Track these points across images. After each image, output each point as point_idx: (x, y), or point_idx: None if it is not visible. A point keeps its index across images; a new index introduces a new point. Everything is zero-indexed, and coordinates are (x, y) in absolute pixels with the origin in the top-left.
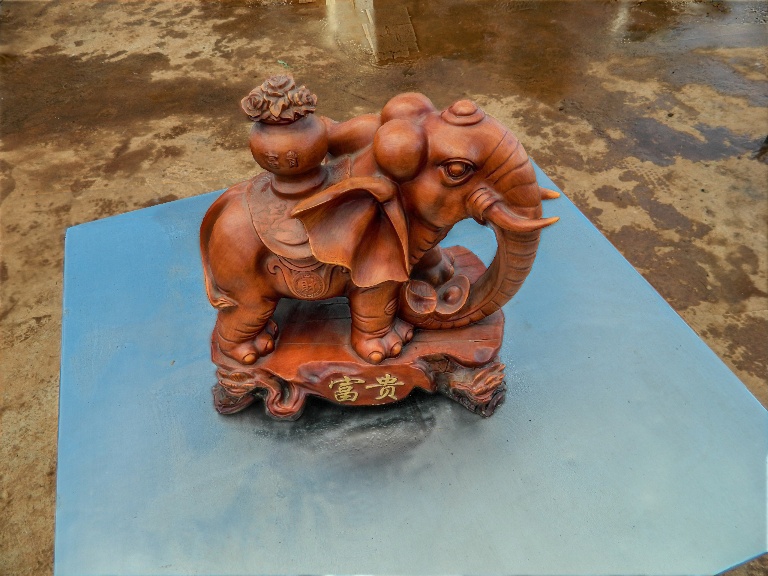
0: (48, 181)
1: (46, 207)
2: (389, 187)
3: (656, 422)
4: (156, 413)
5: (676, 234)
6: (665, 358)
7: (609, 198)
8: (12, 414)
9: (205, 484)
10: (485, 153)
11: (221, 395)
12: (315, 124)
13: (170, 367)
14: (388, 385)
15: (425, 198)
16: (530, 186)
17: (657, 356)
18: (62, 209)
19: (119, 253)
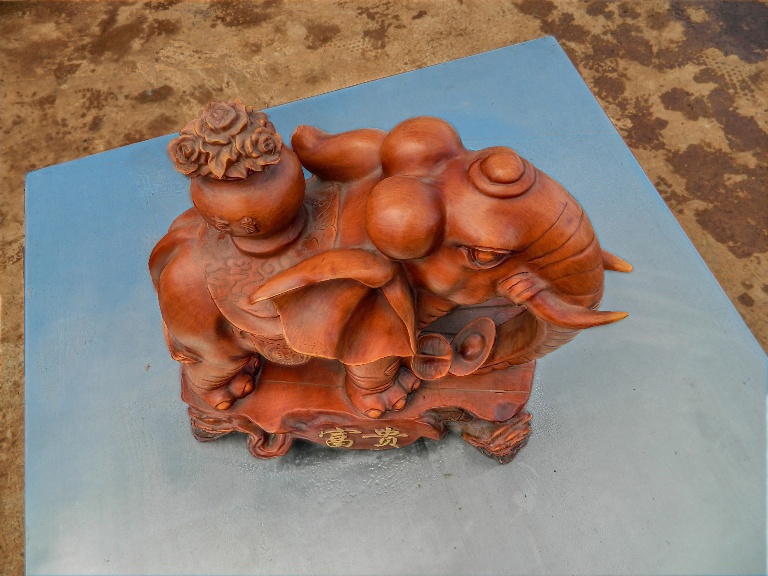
0: (29, 63)
1: (29, 97)
2: (387, 271)
3: (705, 482)
4: (129, 432)
5: (753, 158)
6: (728, 395)
7: (678, 106)
8: (10, 347)
9: (182, 526)
10: (530, 236)
11: (197, 428)
12: (283, 169)
13: (144, 373)
14: (389, 436)
15: (438, 282)
16: (591, 273)
17: (718, 392)
18: (46, 101)
19: (86, 213)
